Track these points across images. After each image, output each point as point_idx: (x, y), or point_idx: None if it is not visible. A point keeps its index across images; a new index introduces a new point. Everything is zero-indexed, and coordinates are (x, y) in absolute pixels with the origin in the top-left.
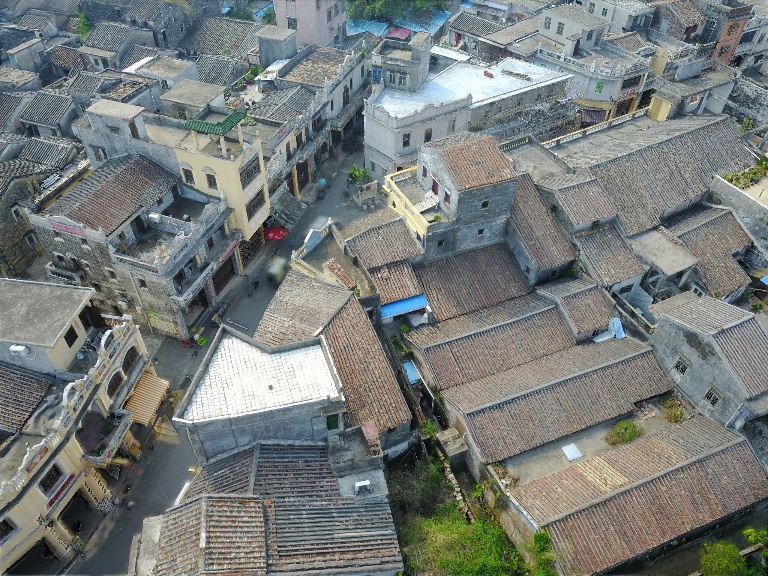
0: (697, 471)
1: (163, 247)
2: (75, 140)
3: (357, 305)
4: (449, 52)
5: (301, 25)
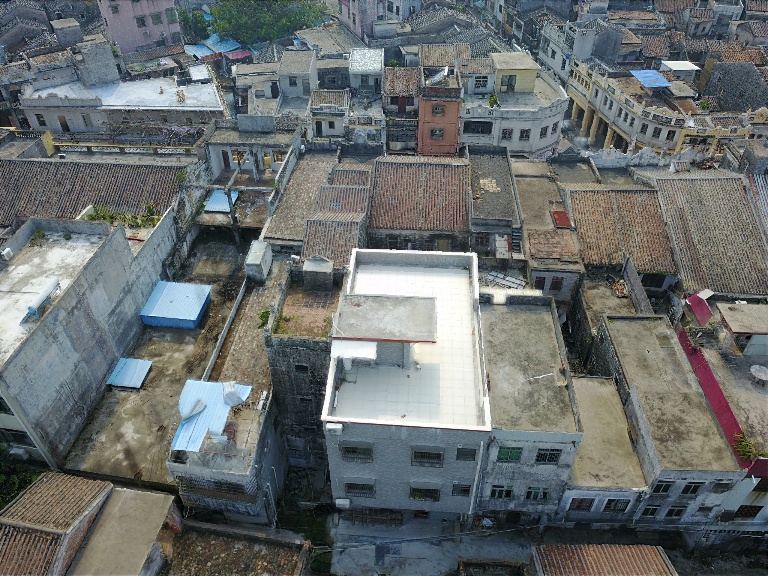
0: None
1: None
2: None
3: None
4: (202, 71)
5: (108, 24)
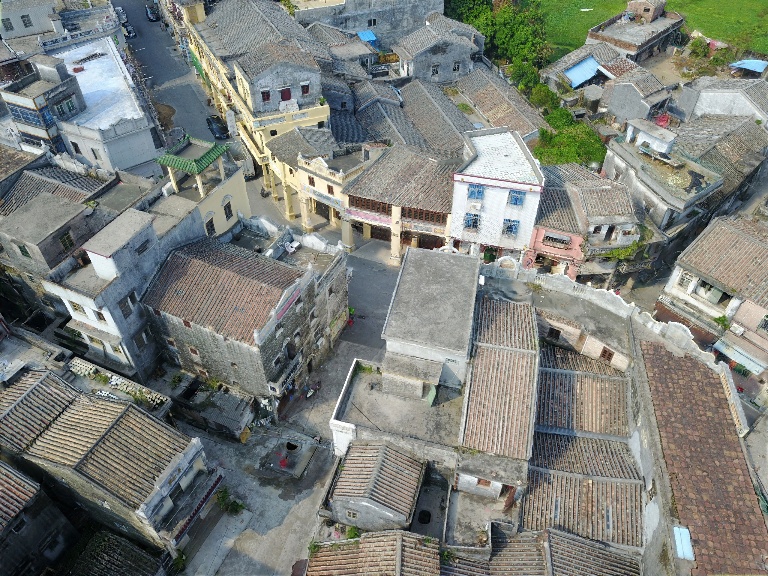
0: (497, 85)
1: (299, 263)
2: (1, 392)
3: (405, 145)
4: None
5: None
